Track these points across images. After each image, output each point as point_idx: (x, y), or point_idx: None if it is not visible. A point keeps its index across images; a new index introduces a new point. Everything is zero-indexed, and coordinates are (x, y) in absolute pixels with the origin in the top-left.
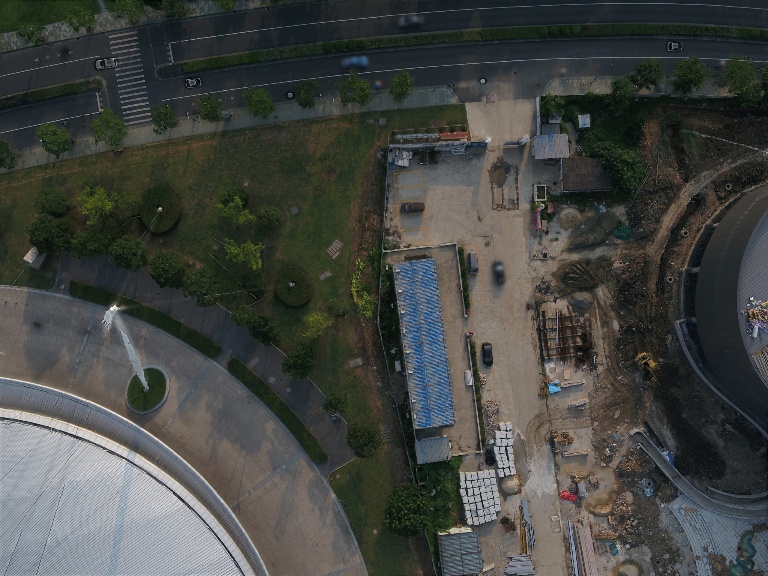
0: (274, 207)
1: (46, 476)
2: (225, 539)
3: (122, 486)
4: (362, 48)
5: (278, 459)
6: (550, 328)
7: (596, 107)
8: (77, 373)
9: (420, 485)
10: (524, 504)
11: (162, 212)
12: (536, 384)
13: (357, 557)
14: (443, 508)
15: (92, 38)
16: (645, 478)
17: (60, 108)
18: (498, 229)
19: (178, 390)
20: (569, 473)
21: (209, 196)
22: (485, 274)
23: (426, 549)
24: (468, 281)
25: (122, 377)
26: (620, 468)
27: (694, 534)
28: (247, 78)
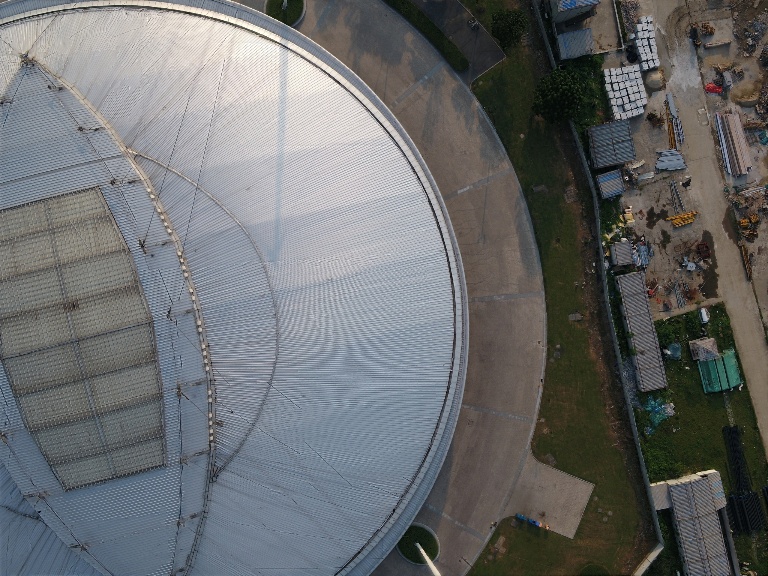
0: None
1: (206, 52)
2: (383, 120)
3: (279, 64)
4: None
5: (419, 70)
6: None
7: None
8: None
9: None
10: (670, 98)
11: None
12: None
13: (506, 163)
14: (589, 107)
15: None
16: None
17: None
18: None
19: (315, 7)
20: (712, 65)
21: None
22: None
23: (574, 150)
24: None
25: None
26: (764, 56)
27: None
28: None
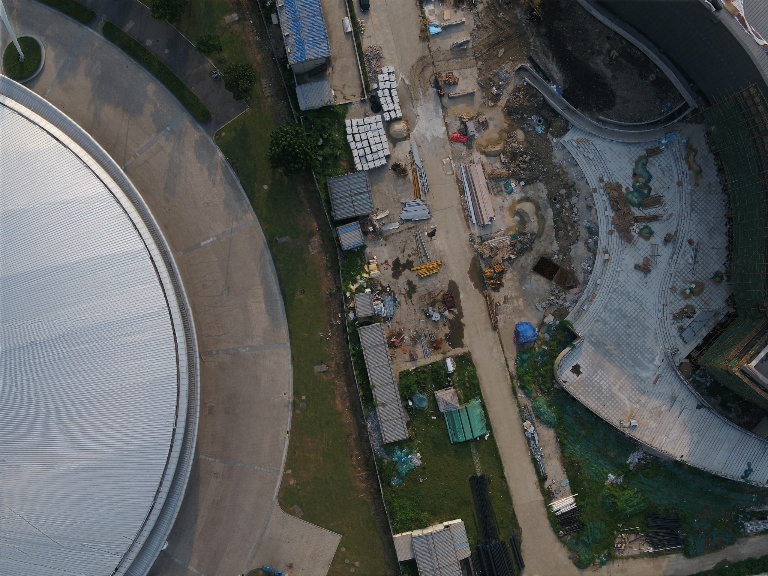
0: None
1: None
2: (104, 176)
3: None
4: None
5: (161, 121)
6: None
7: None
8: None
9: (306, 134)
10: (414, 148)
11: None
12: (416, 27)
13: (250, 214)
14: (332, 157)
15: None
16: (535, 115)
17: None
18: None
19: (55, 59)
20: (457, 115)
21: None
22: None
23: (319, 201)
24: None
25: None
26: (508, 105)
27: (588, 166)
28: None
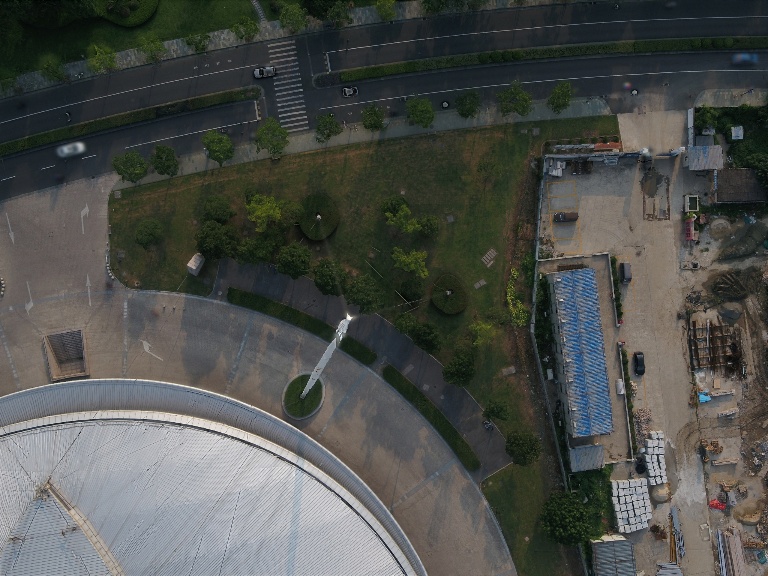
0: (435, 216)
1: (222, 481)
2: (391, 545)
3: (294, 492)
4: (517, 59)
5: (431, 466)
6: (700, 338)
7: (747, 119)
8: (234, 379)
9: (572, 493)
10: (674, 512)
11: (321, 220)
12: (686, 393)
13: (509, 564)
14: (594, 516)
15: (251, 47)
16: None
17: (219, 116)
18: (649, 239)
19: (333, 396)
20: (718, 482)
21: (366, 204)
22: (636, 284)
23: (577, 556)
24: (620, 290)
25: (278, 383)
26: None
27: None
28: (403, 88)
